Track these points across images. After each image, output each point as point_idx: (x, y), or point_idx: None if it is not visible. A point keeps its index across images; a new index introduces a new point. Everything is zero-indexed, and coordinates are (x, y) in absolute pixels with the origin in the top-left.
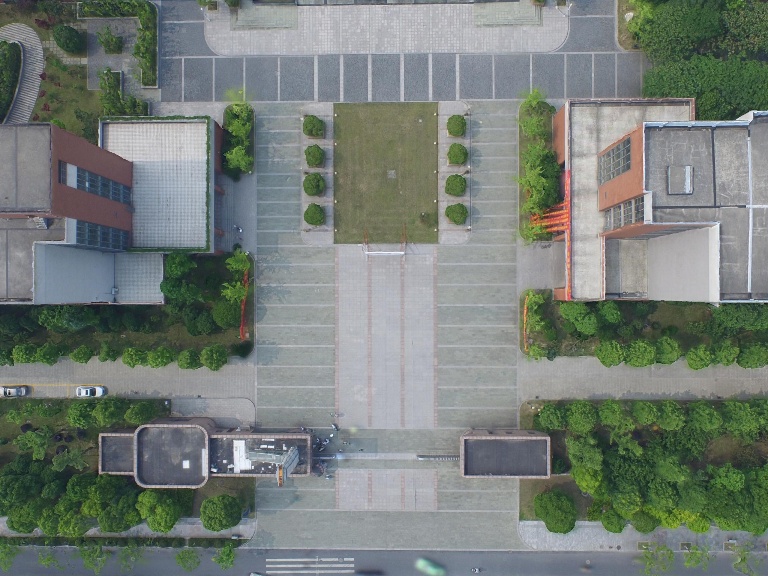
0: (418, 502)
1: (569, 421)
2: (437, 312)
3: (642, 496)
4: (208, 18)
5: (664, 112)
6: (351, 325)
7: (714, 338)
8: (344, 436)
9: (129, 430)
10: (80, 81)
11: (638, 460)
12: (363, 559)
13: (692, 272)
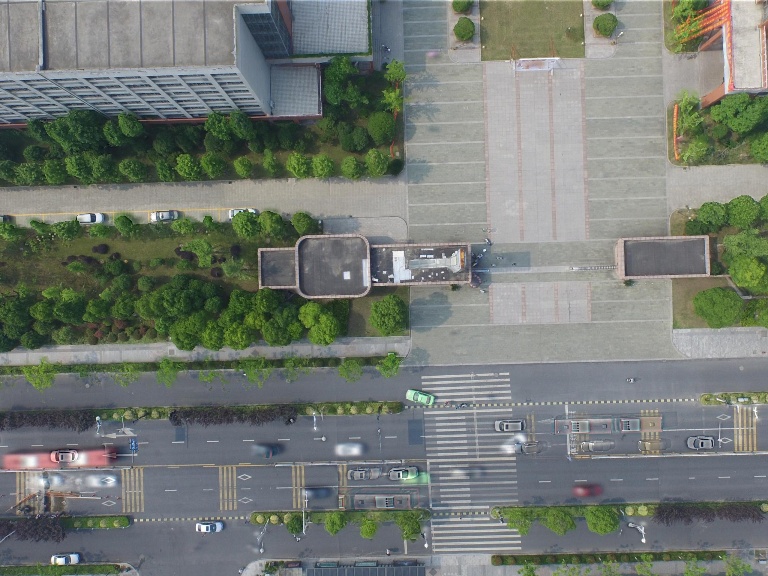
0: (572, 314)
1: (732, 213)
2: (586, 125)
3: None
4: None
5: None
6: (501, 141)
7: None
8: (497, 251)
9: None
10: None
11: None
12: (518, 373)
13: None
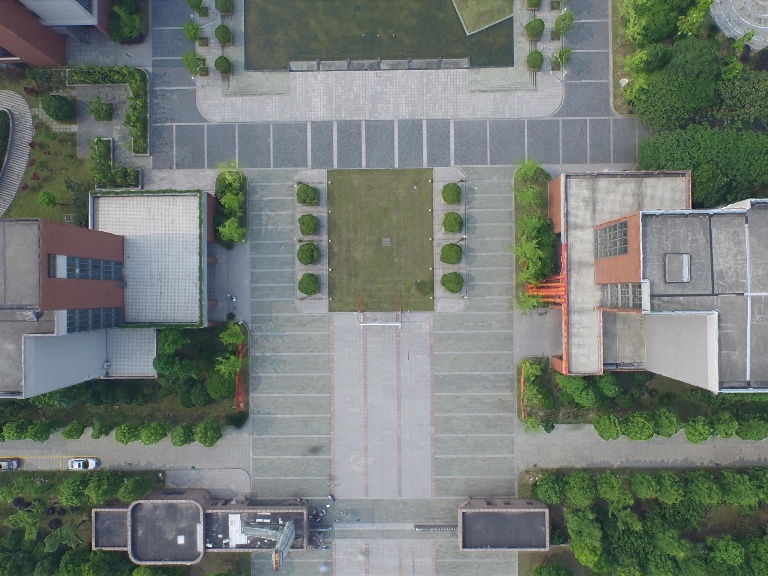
0: (416, 572)
1: (567, 495)
2: (433, 380)
3: (641, 568)
4: (199, 84)
5: (660, 184)
6: (347, 394)
7: (712, 408)
8: (341, 506)
9: (123, 503)
10: (70, 149)
11: (637, 531)
12: None
13: (690, 355)
